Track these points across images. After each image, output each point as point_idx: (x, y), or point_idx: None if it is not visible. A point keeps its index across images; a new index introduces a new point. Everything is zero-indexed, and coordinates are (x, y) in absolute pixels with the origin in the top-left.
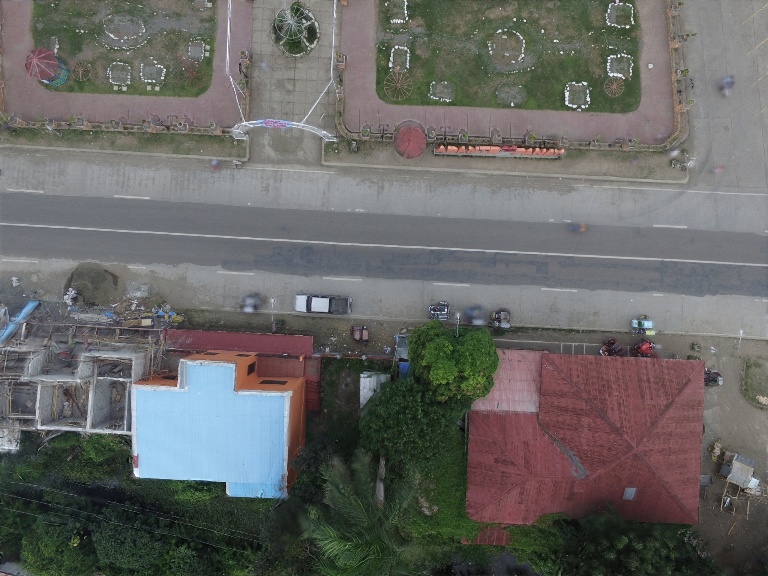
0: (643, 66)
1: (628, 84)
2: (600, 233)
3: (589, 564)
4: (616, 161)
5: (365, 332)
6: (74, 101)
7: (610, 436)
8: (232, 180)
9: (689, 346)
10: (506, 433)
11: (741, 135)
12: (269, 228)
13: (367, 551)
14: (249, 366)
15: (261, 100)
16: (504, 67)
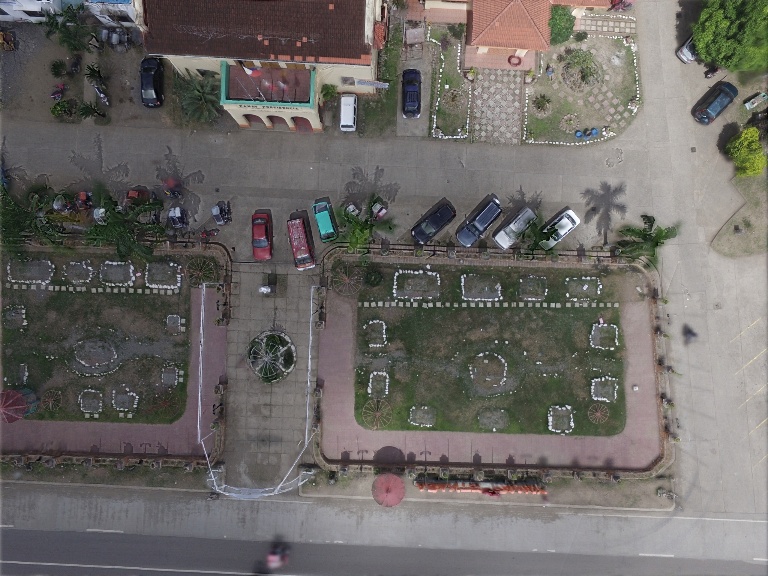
0: (628, 387)
1: (613, 406)
2: (585, 563)
3: None
4: (601, 489)
5: None
6: (44, 429)
7: None
8: (207, 512)
9: None
10: None
11: (728, 458)
12: (246, 562)
13: None
14: None
15: (237, 426)
16: (486, 390)
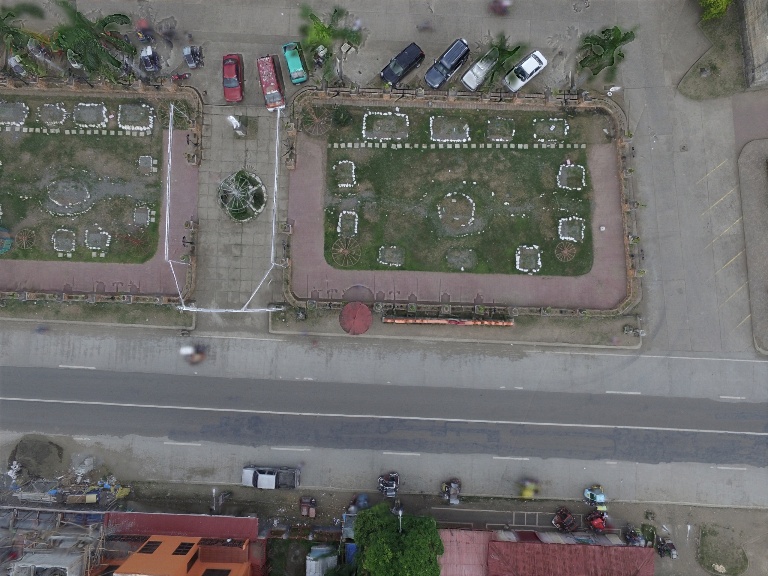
0: (595, 228)
1: (580, 247)
2: (552, 400)
3: None
4: (568, 327)
5: (312, 510)
6: (18, 268)
7: None
8: (178, 349)
9: (643, 515)
10: None
11: (695, 298)
12: (216, 398)
13: None
14: (189, 562)
15: (208, 266)
16: (454, 231)
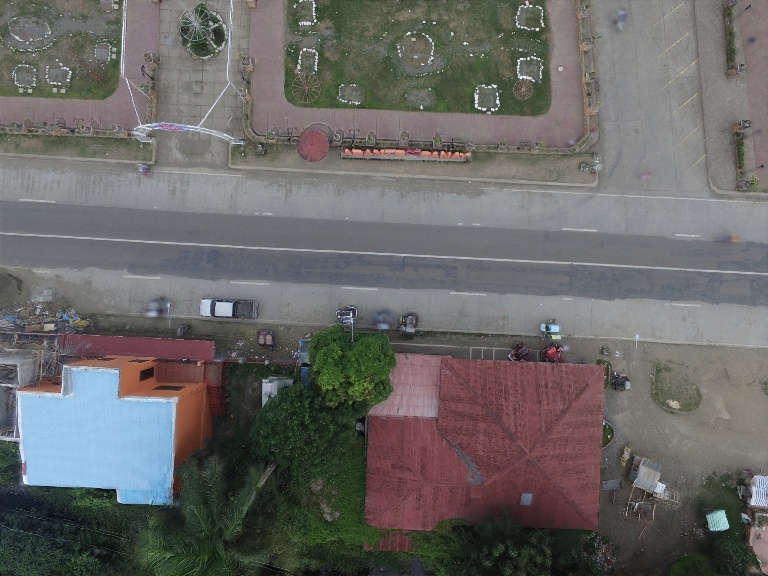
0: (553, 69)
1: (538, 87)
2: (509, 237)
3: (469, 572)
4: (525, 164)
5: (269, 337)
6: None
7: (504, 442)
8: (138, 183)
9: (599, 350)
10: (404, 439)
11: (651, 138)
12: (175, 232)
13: (192, 563)
14: (142, 372)
15: (168, 103)
16: (413, 70)
